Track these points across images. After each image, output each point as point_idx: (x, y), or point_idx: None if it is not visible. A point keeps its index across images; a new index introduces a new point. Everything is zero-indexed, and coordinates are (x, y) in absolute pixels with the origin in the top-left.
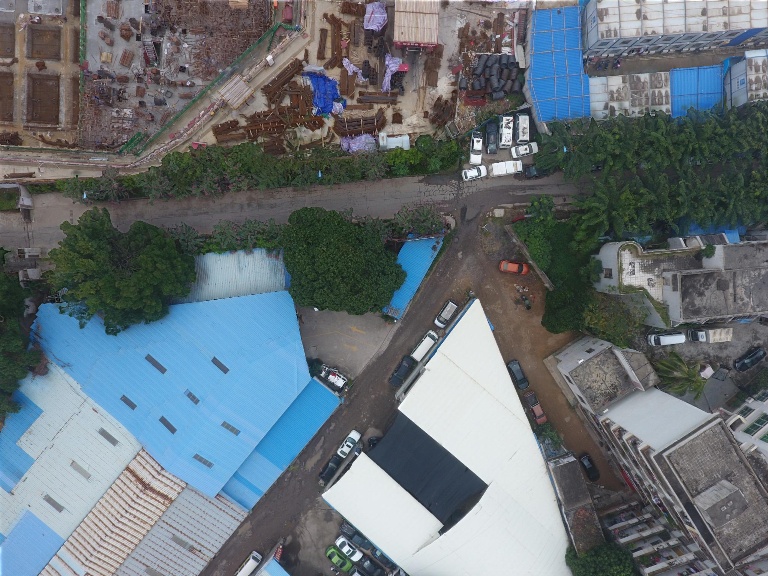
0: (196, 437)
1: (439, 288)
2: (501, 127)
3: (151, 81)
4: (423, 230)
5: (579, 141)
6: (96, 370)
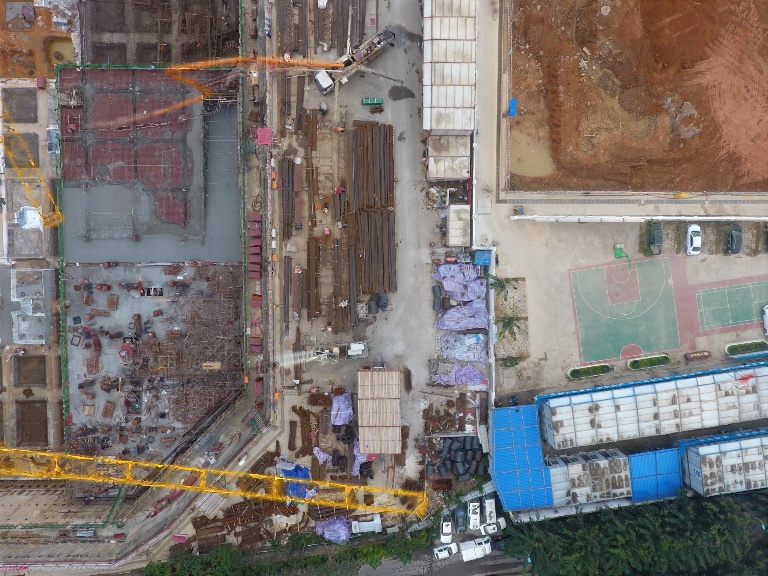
0: None
1: None
2: (469, 511)
3: (133, 434)
4: None
5: (543, 539)
6: None
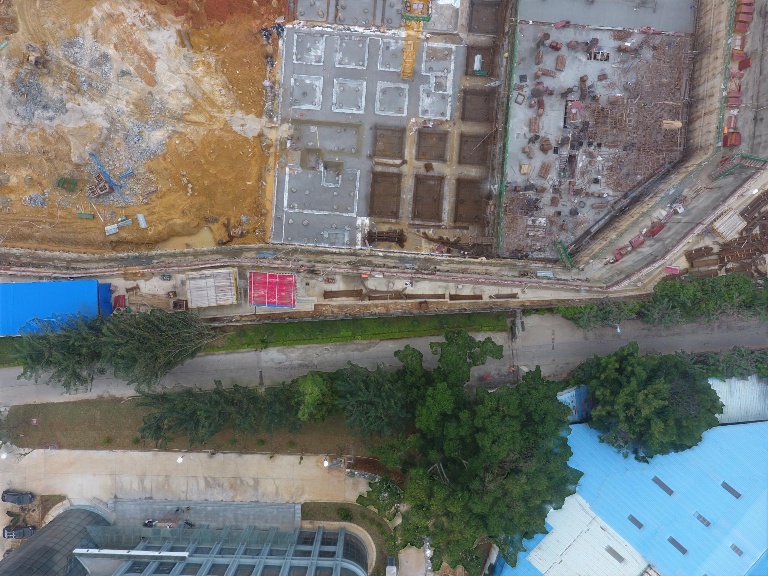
0: (708, 558)
1: None
2: None
3: None
4: None
5: None
6: (604, 490)
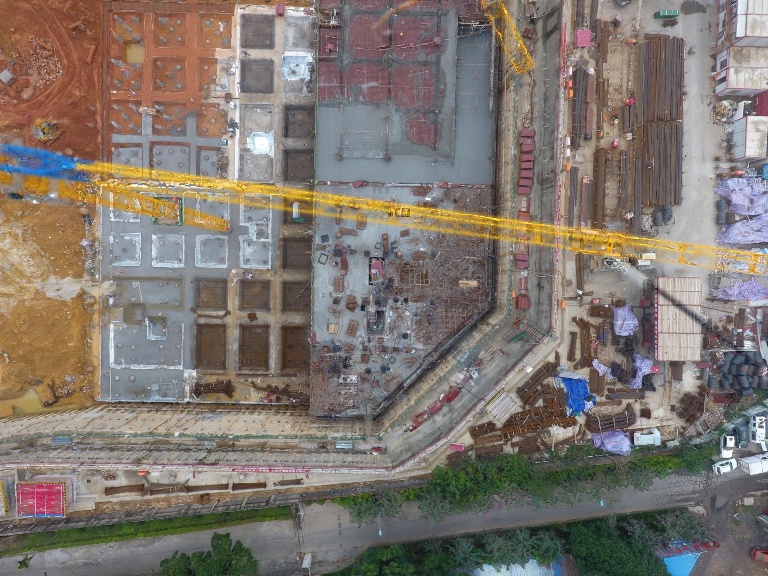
0: None
1: (692, 575)
2: (753, 425)
3: (379, 353)
4: (691, 538)
5: None
6: None
